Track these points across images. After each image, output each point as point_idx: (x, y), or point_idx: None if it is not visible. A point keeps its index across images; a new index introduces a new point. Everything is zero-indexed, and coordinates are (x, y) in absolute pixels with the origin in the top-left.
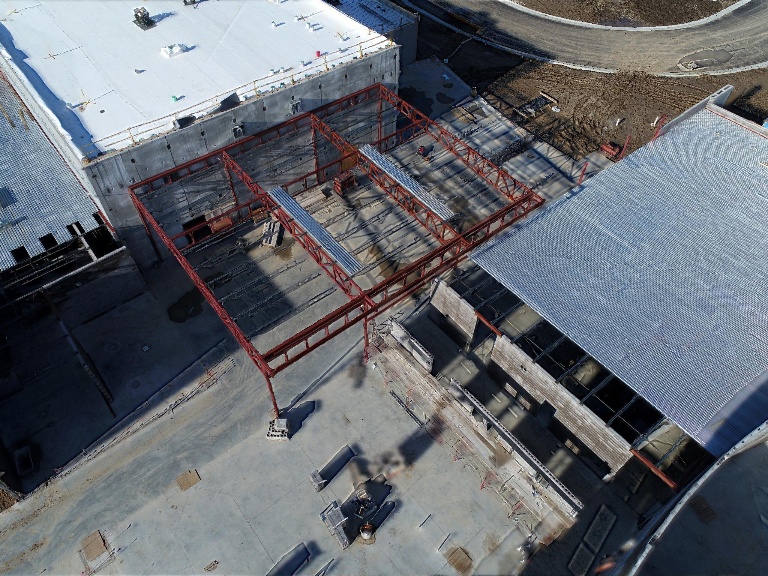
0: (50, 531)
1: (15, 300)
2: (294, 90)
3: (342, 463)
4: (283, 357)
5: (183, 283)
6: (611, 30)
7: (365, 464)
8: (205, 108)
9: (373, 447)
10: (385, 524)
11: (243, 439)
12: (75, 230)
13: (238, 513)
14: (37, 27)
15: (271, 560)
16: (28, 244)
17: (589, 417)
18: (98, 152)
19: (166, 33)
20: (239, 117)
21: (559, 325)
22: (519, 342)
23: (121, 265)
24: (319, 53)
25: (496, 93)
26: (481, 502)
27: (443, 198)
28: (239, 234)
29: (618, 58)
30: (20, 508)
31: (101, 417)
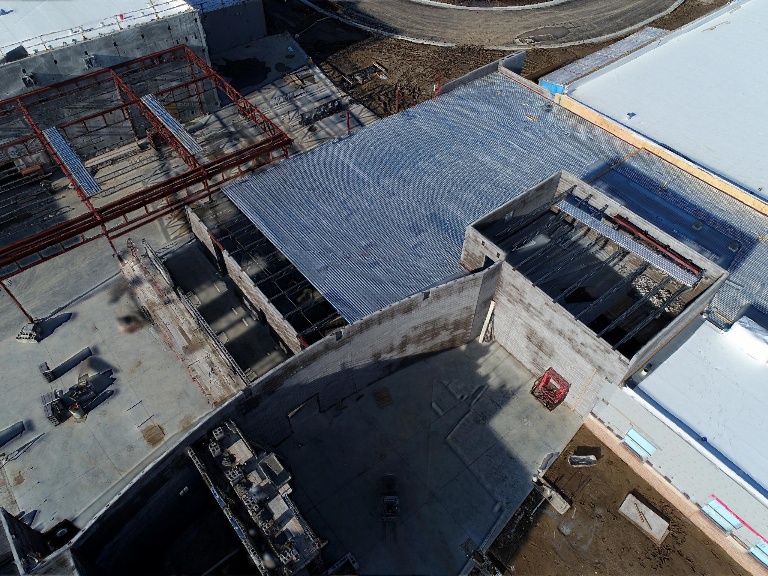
0: None
1: None
2: (85, 46)
3: (78, 361)
4: (56, 278)
5: None
6: (465, 10)
7: (99, 362)
8: None
9: (110, 349)
10: (99, 407)
11: None
12: None
13: None
14: None
15: None
16: None
17: (274, 313)
18: None
19: None
20: (28, 68)
21: (277, 242)
22: (248, 259)
23: None
24: (121, 16)
25: (333, 63)
26: (190, 391)
27: None
28: (52, 180)
29: (461, 34)
30: None
31: None
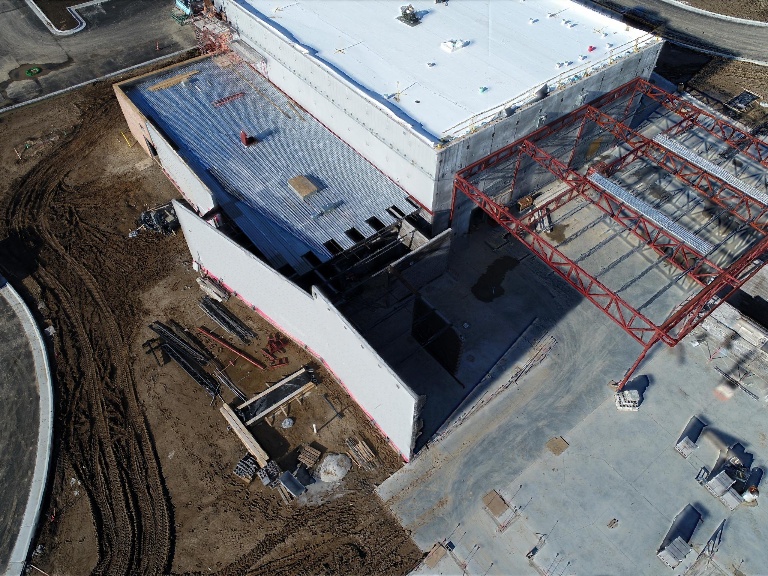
0: (449, 489)
1: (371, 277)
2: (586, 82)
3: (696, 432)
4: (599, 335)
5: (475, 266)
6: None
7: (718, 434)
8: (524, 98)
9: (720, 418)
10: (761, 488)
11: (593, 409)
12: (394, 213)
13: (618, 476)
14: (308, 24)
15: (667, 519)
16: (358, 226)
17: None
18: (436, 139)
19: (434, 29)
20: (544, 107)
21: None
22: None
23: (441, 246)
24: (591, 48)
25: (699, 89)
26: None
27: (690, 188)
28: None
29: None
30: (412, 468)
31: (451, 387)
